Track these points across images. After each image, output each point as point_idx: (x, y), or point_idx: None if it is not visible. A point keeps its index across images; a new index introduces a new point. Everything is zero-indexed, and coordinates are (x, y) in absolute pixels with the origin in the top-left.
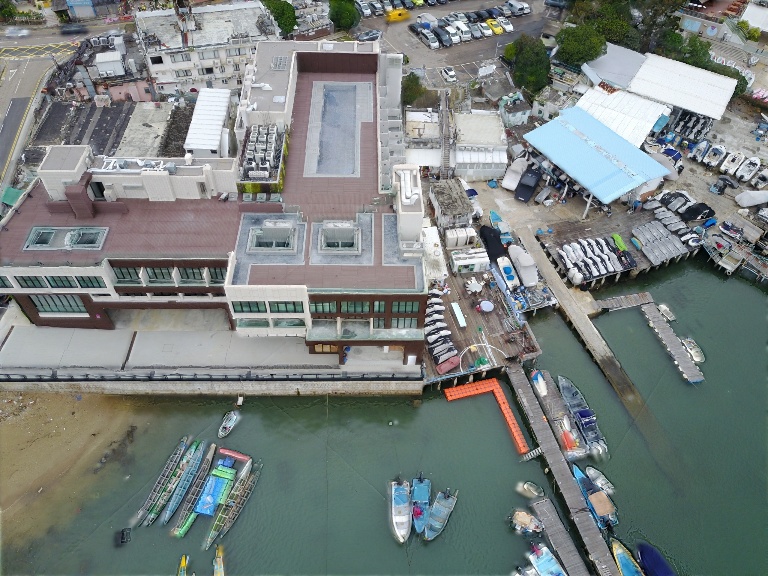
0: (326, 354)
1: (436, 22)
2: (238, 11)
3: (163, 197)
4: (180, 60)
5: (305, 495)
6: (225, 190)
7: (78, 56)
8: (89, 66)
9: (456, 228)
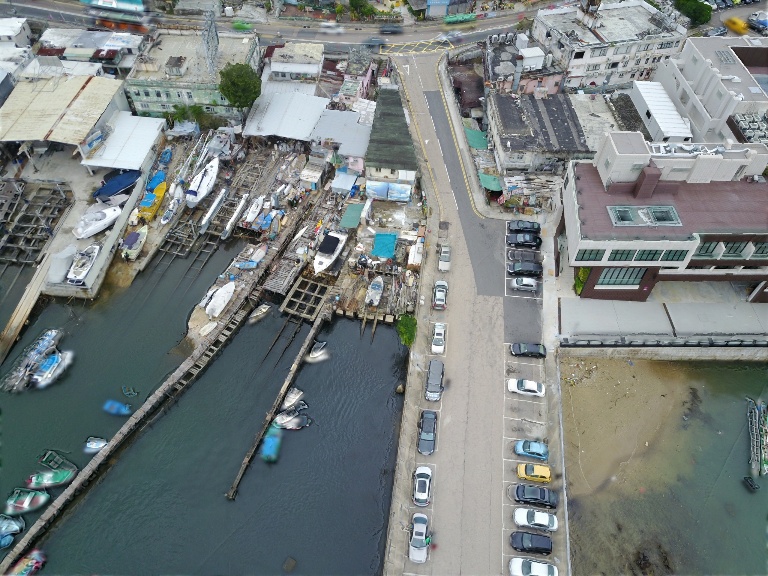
0: None
1: None
2: (623, 9)
3: (702, 179)
4: (597, 55)
5: None
6: (750, 173)
7: (484, 52)
8: (501, 61)
9: None
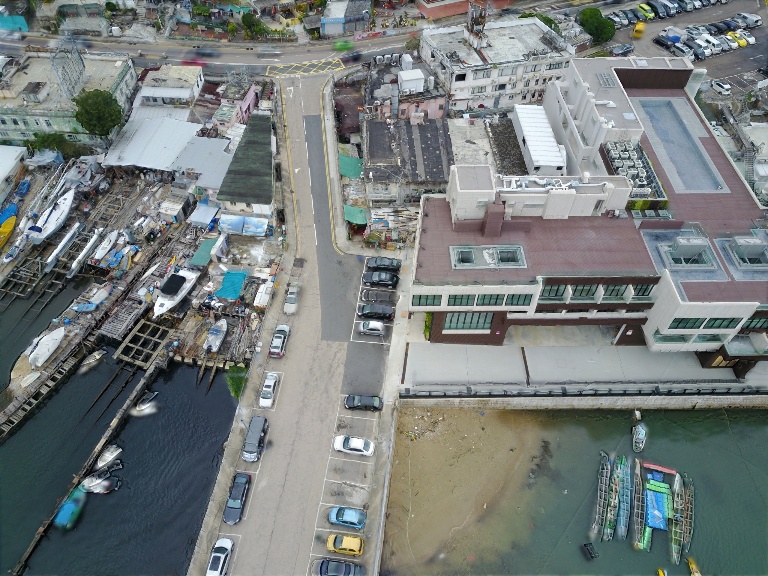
0: (719, 368)
1: (686, 35)
2: (515, 27)
3: (558, 215)
4: (480, 77)
5: (742, 509)
6: (613, 207)
7: (367, 74)
8: (383, 84)
9: None
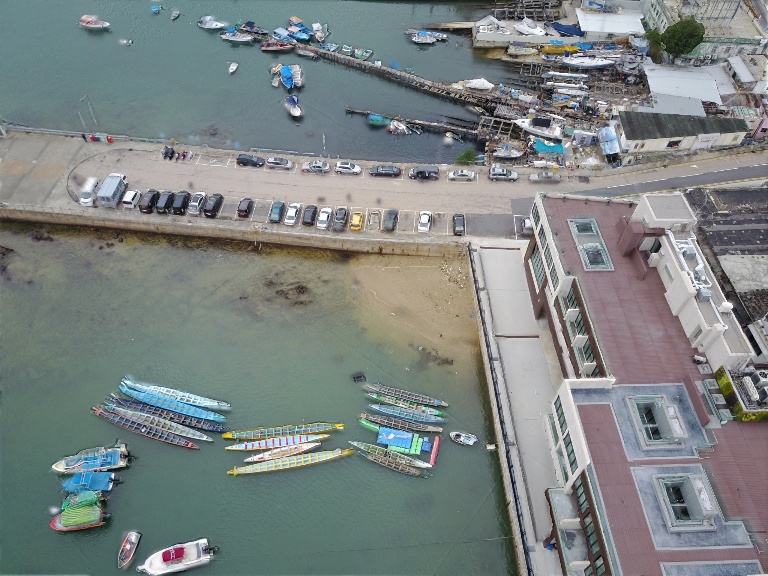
0: None
1: None
2: None
3: (672, 303)
4: None
5: (402, 525)
6: (711, 359)
7: None
8: None
9: None
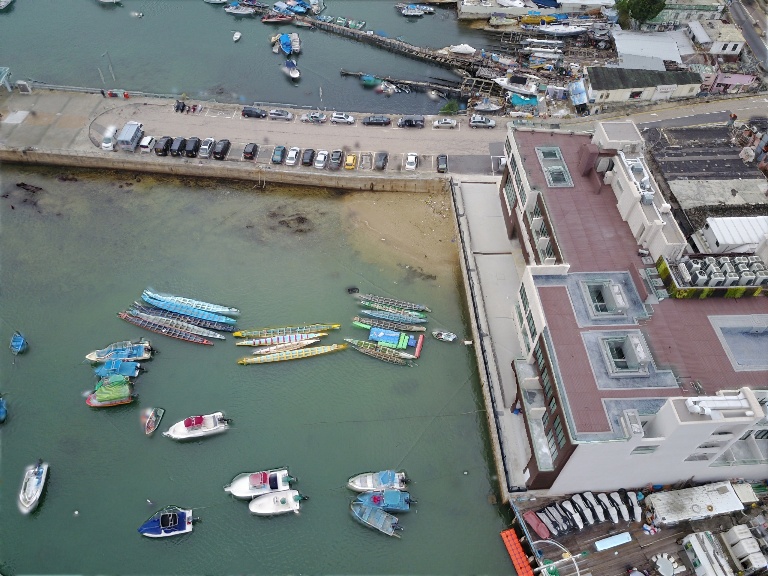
0: None
1: None
2: None
3: (622, 211)
4: None
5: (390, 403)
6: (653, 252)
7: None
8: None
9: (756, 538)
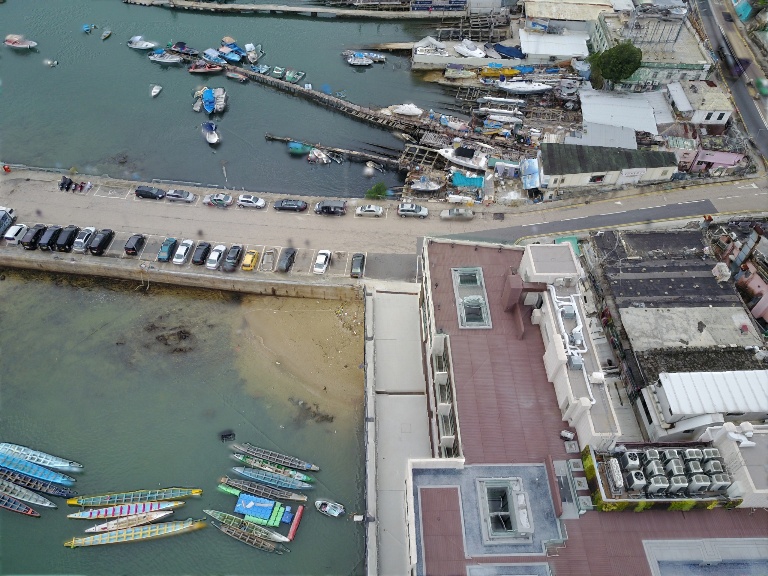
0: None
1: None
2: None
3: (548, 368)
4: None
5: None
6: (580, 435)
7: None
8: None
9: None
